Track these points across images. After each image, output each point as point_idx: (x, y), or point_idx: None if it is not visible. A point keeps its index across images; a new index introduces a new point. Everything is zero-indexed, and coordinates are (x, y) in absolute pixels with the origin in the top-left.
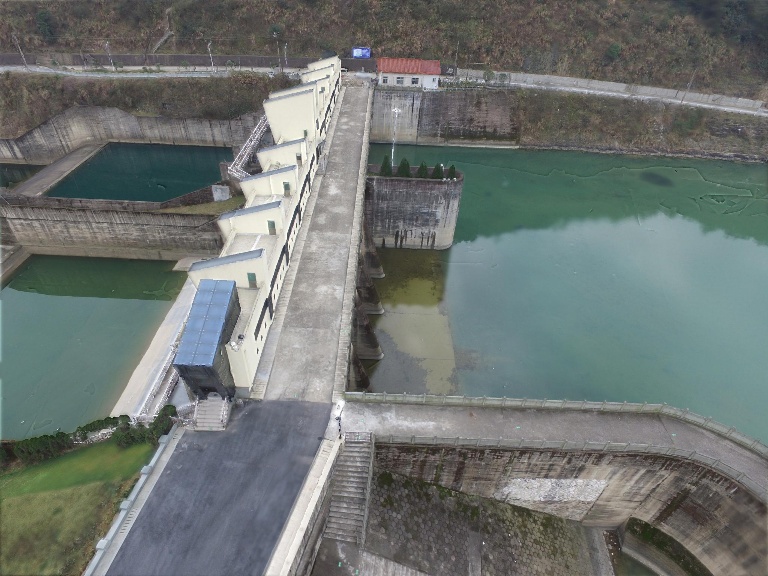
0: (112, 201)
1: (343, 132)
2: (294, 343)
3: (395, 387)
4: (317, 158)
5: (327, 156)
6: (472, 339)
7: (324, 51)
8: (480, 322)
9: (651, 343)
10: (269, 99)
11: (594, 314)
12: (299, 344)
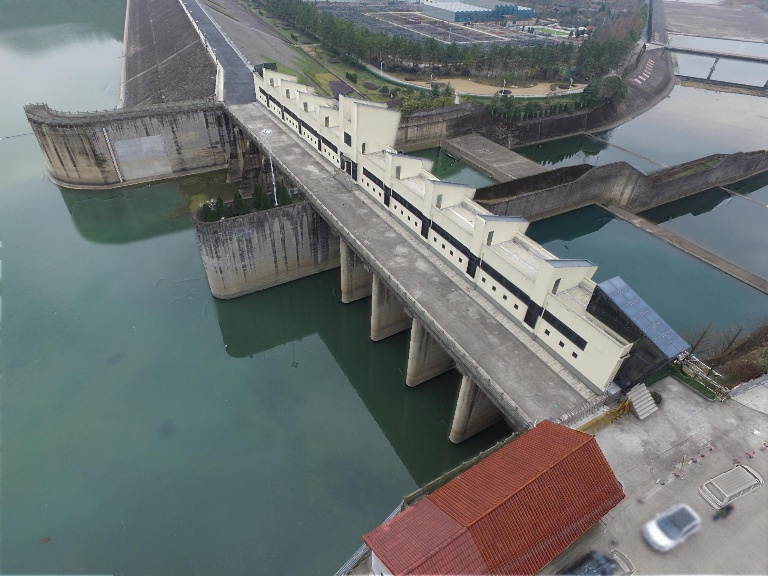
0: (523, 195)
1: (390, 238)
2: (255, 112)
3: (224, 191)
4: (345, 166)
5: (359, 196)
6: (179, 225)
7: (614, 279)
8: (173, 236)
9: (14, 264)
10: (384, 104)
11: (58, 274)
12: (253, 112)
